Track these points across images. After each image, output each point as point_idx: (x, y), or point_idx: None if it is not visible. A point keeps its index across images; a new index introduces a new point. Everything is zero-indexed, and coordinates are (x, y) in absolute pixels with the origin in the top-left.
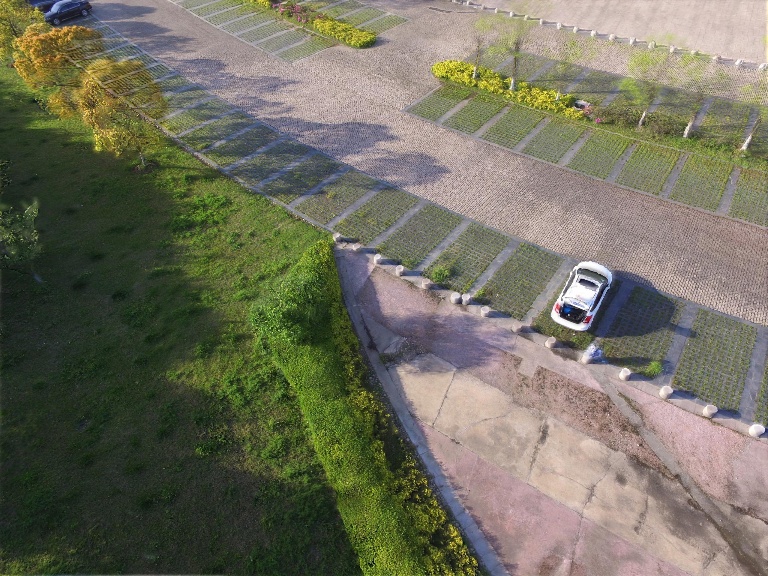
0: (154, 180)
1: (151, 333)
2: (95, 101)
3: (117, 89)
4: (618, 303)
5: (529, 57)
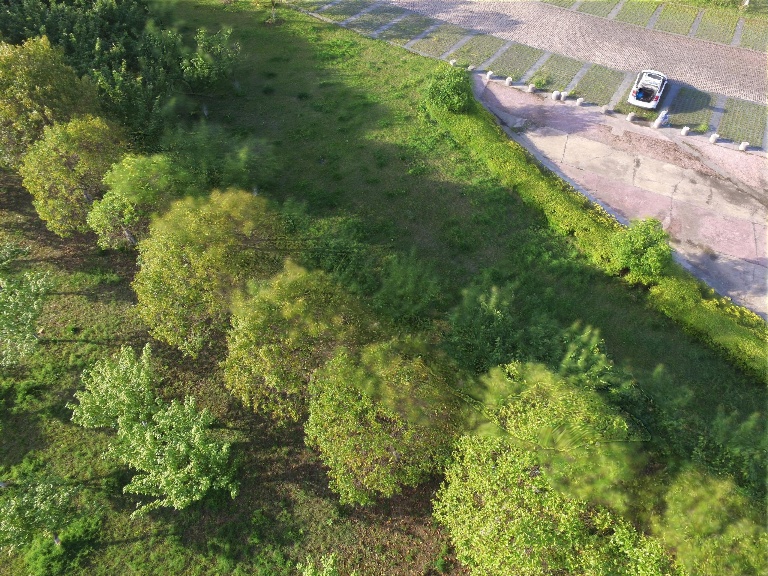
0: (286, 30)
1: (342, 115)
2: None
3: None
4: (671, 96)
5: None
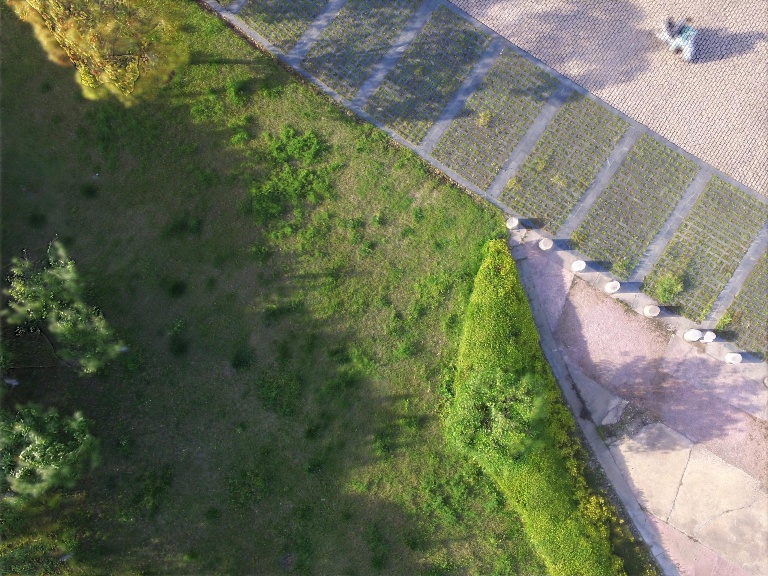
0: (183, 99)
1: (311, 426)
2: (52, 2)
3: None
4: None
5: None
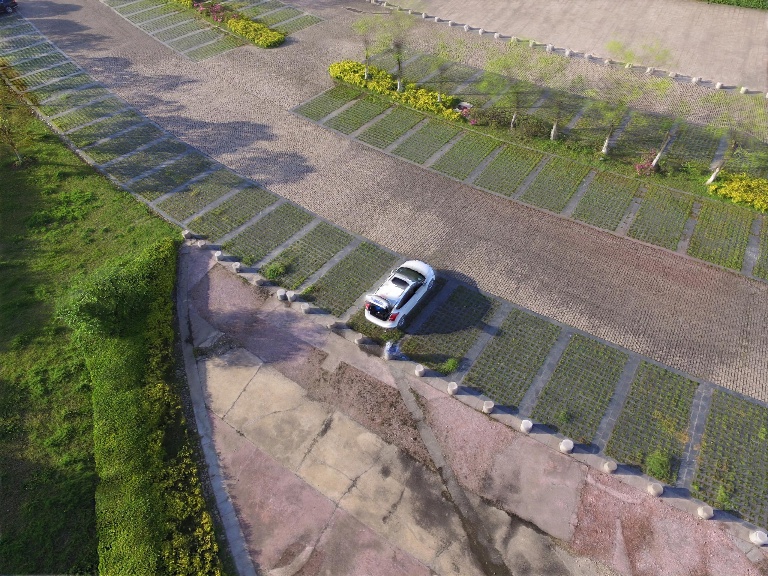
0: (27, 176)
1: None
2: None
3: (21, 86)
4: (437, 301)
5: (428, 59)
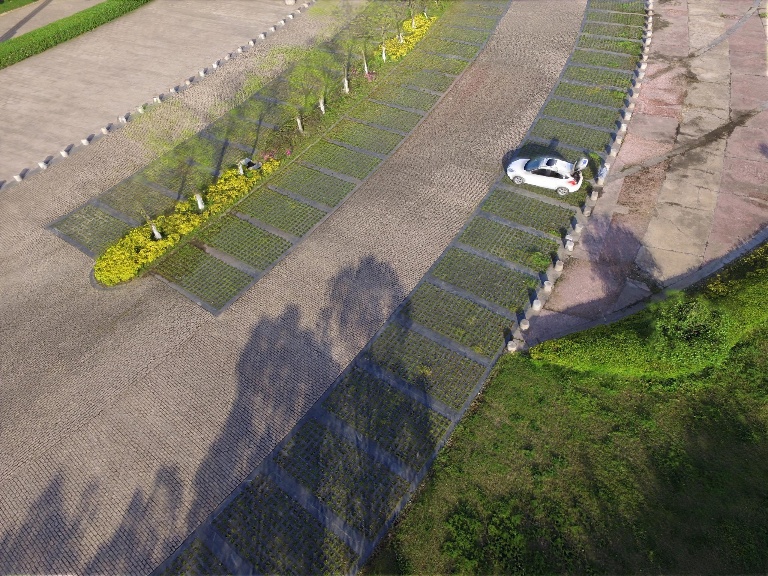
0: None
1: (766, 503)
2: None
3: None
4: None
5: (113, 195)
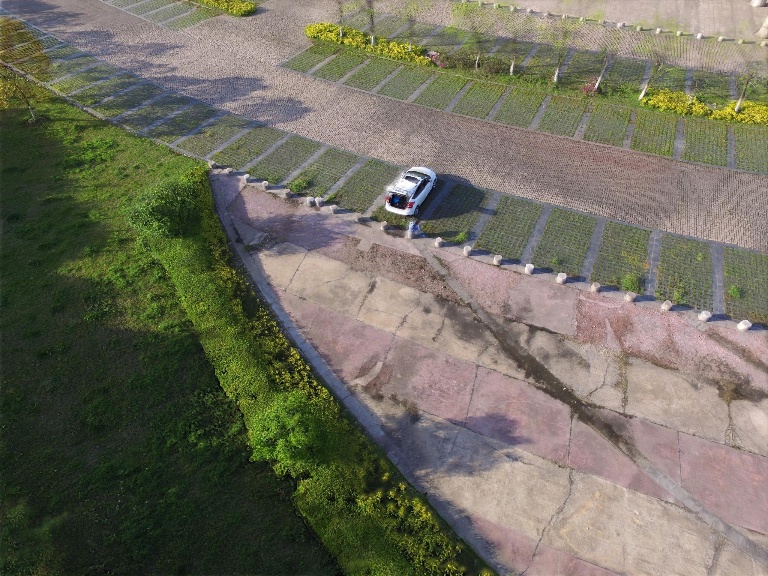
0: (45, 131)
1: (43, 243)
2: None
3: (6, 59)
4: (441, 196)
5: (392, 19)
